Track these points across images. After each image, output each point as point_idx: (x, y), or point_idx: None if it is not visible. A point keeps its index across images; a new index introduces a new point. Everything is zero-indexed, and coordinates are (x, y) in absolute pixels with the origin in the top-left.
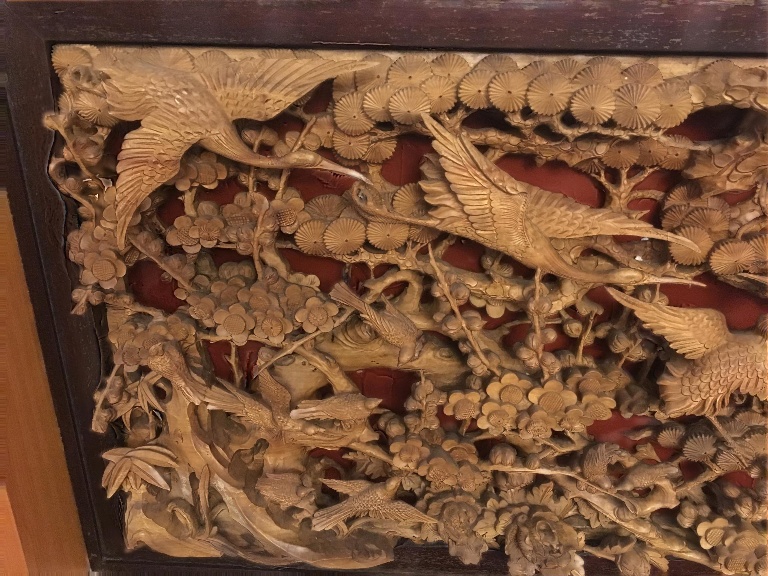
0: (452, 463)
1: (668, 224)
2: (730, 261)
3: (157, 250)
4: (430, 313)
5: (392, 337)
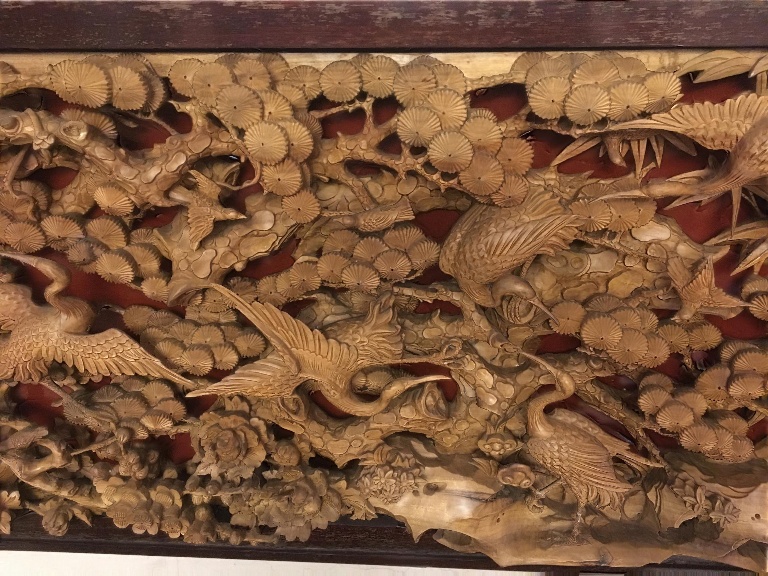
0: None
1: None
2: (16, 240)
3: None
4: None
5: None
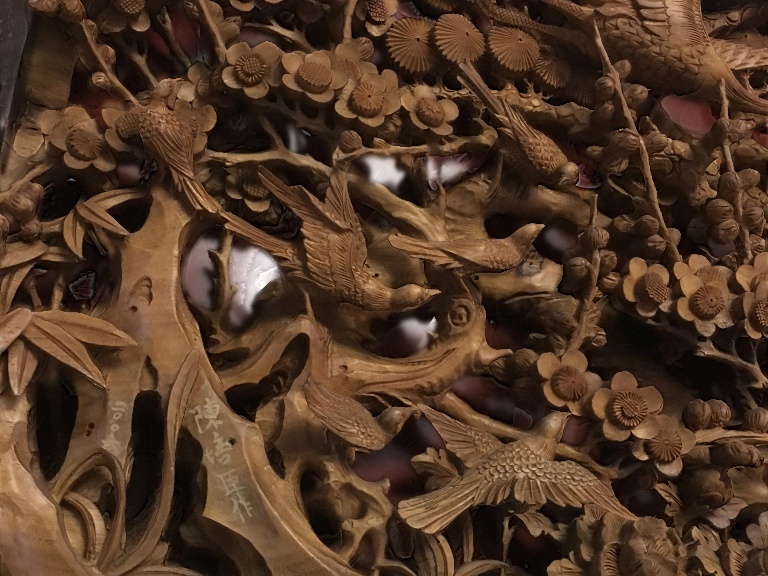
0: None
1: None
2: None
3: None
4: None
5: (544, 148)
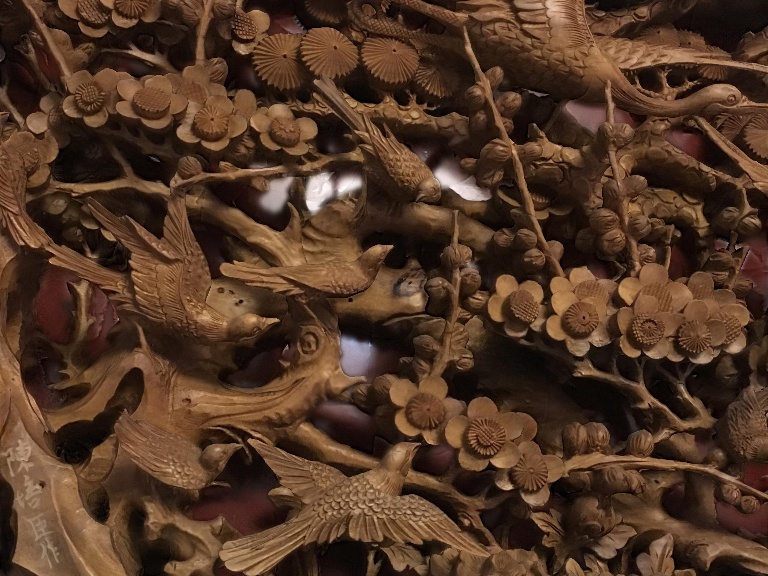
0: (509, 412)
1: (730, 134)
2: None
3: (41, 5)
4: None
5: (405, 163)
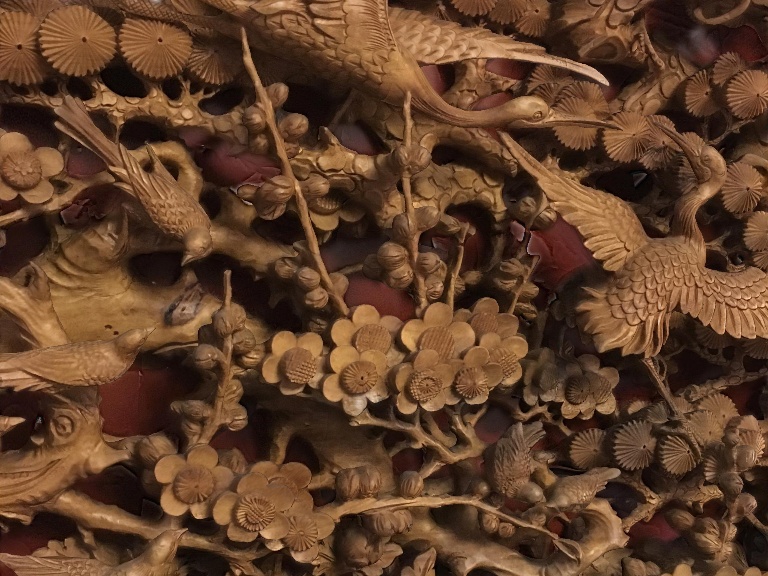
0: None
1: None
2: (627, 135)
3: None
4: (219, 221)
5: (171, 210)
